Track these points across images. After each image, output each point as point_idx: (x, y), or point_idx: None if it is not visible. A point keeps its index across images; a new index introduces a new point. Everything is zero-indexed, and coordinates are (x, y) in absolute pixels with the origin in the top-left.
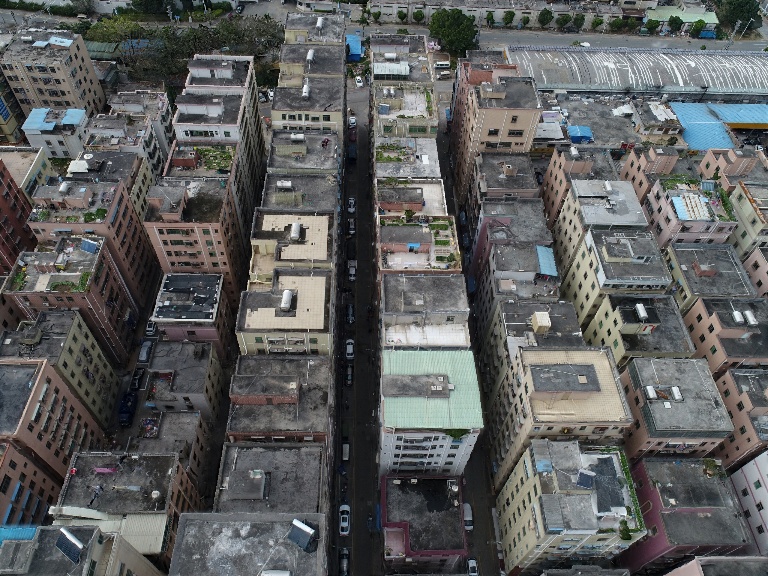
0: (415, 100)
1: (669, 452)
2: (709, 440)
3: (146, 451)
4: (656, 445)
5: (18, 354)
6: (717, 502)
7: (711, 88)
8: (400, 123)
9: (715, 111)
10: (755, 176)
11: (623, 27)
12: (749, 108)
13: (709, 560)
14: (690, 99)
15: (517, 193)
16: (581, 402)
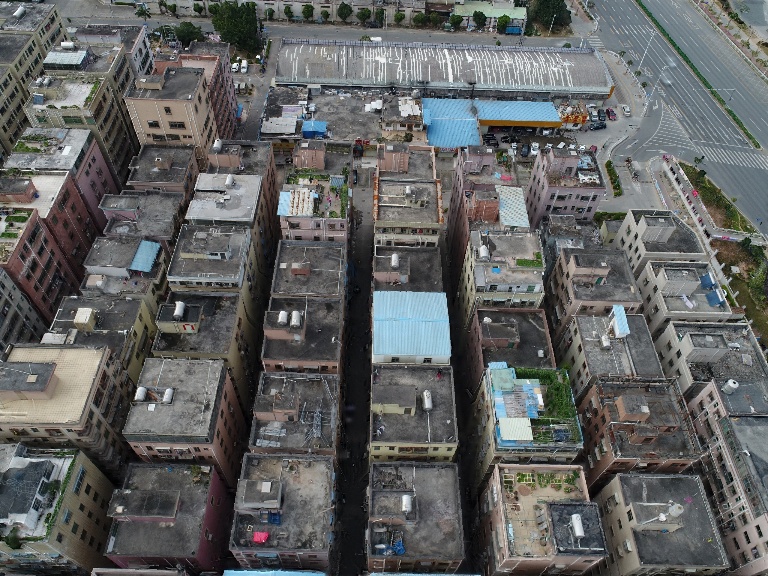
0: (70, 90)
1: (170, 457)
2: (197, 445)
3: None
4: (149, 450)
5: None
6: (168, 511)
7: (479, 84)
8: (51, 113)
9: (477, 108)
10: (416, 172)
11: (428, 22)
12: (516, 105)
13: (110, 572)
14: (461, 95)
15: (164, 187)
16: (41, 402)
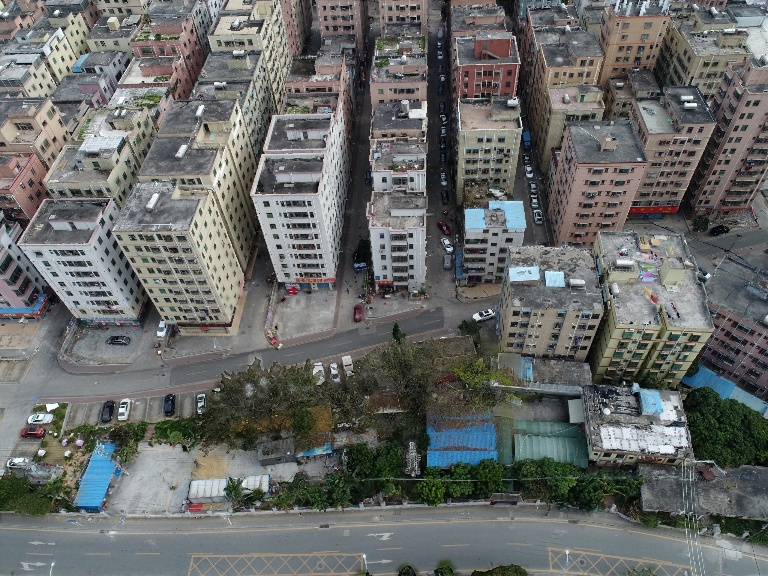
0: (100, 114)
1: None
2: None
3: (346, 42)
4: None
5: (410, 30)
6: None
7: None
8: None
9: None
10: None
11: None
12: None
13: None
14: None
15: None
16: None
